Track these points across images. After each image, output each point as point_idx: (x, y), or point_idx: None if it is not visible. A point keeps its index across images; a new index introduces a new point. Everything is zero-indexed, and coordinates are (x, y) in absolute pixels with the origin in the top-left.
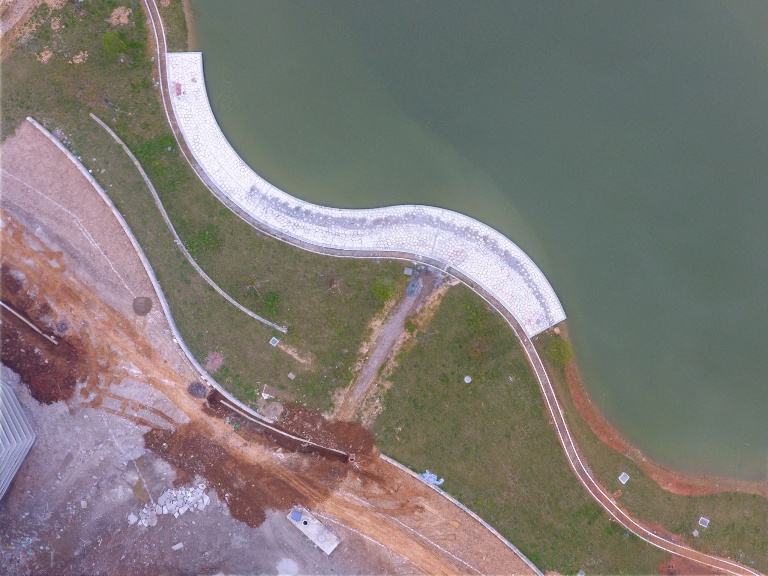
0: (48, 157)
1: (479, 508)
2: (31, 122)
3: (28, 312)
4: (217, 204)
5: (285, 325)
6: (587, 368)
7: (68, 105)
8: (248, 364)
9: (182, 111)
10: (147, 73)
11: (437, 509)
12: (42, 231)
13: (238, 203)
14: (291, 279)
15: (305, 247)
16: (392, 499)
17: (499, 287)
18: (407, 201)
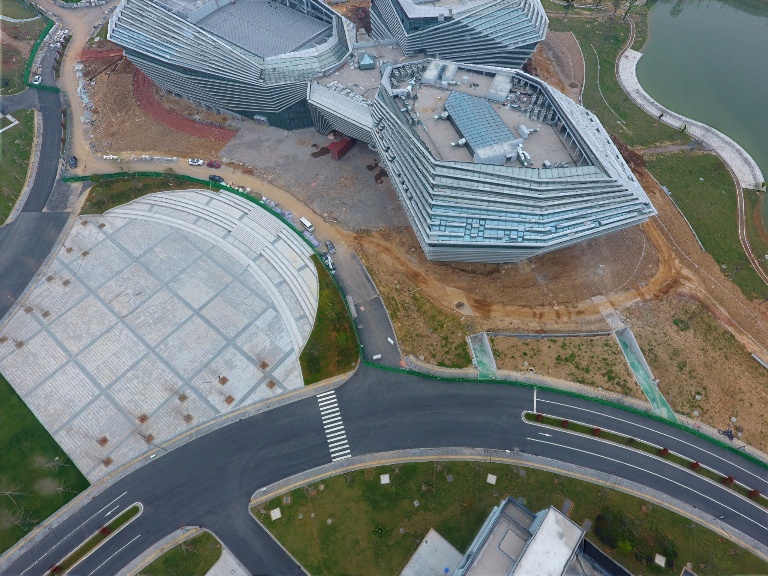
0: (571, 41)
1: (683, 211)
2: (572, 33)
3: (528, 66)
4: (619, 86)
5: (625, 122)
6: (767, 213)
7: (586, 38)
8: (603, 120)
9: (623, 62)
10: (618, 48)
11: (662, 198)
12: (552, 54)
13: (628, 90)
14: (636, 115)
15: (648, 113)
16: (642, 183)
17: (735, 166)
18: (706, 123)
